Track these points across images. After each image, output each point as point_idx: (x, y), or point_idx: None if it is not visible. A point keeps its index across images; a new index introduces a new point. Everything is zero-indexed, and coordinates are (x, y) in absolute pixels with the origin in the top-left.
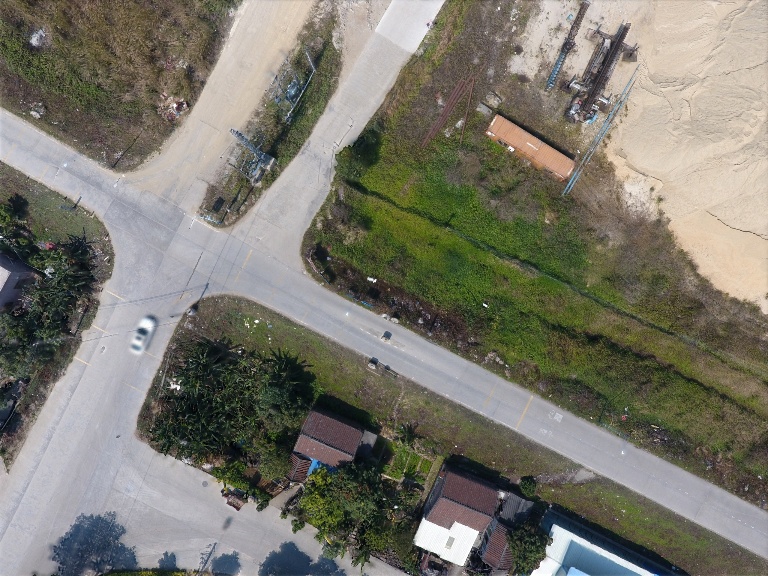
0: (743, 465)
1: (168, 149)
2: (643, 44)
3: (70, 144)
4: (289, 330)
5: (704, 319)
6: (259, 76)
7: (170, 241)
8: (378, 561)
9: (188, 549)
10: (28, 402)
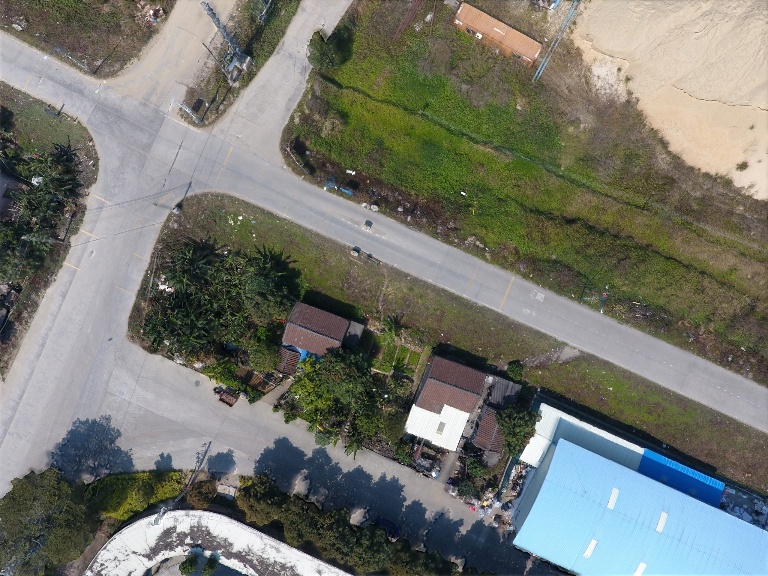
0: (726, 337)
1: (147, 55)
2: None
3: (52, 53)
4: (272, 224)
5: (677, 193)
6: None
7: (152, 143)
8: (372, 453)
9: (184, 449)
10: (21, 309)
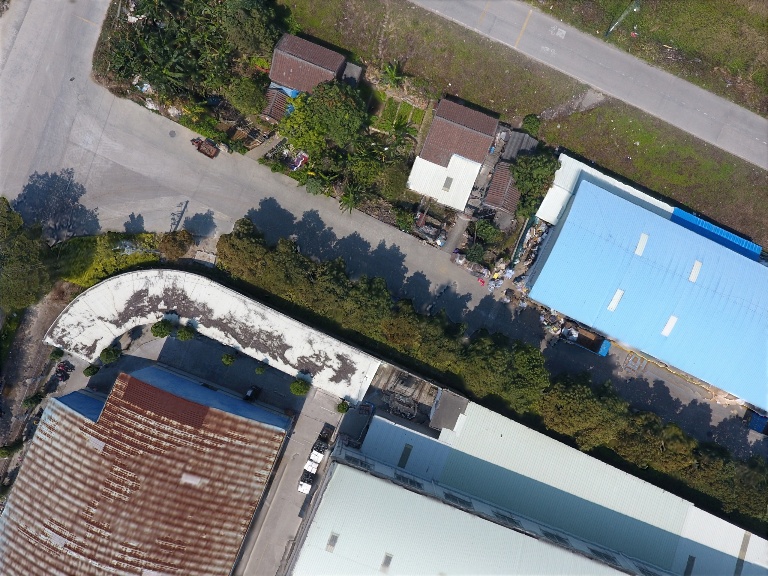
0: (765, 87)
1: None
2: None
3: None
4: None
5: None
6: None
7: None
8: (369, 217)
9: (157, 209)
10: None
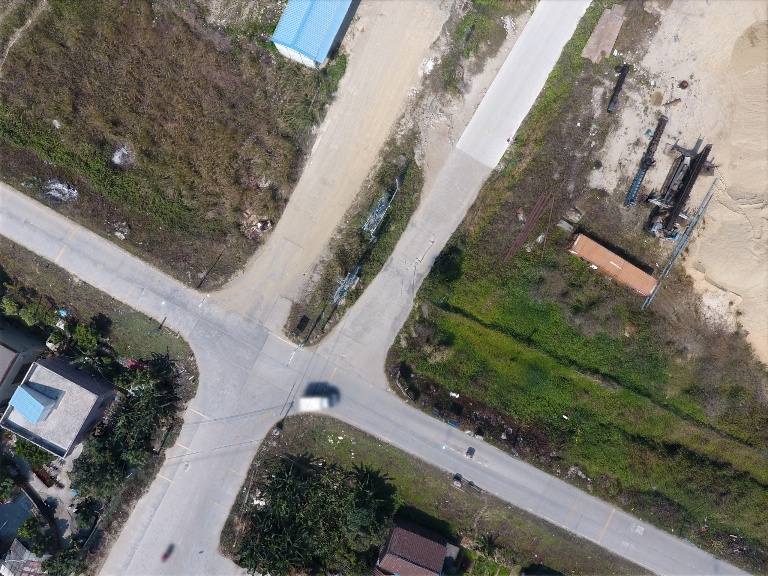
0: None
1: (251, 267)
2: (720, 158)
3: (155, 264)
4: (373, 447)
5: None
6: (341, 193)
7: (255, 360)
8: None
9: None
10: (111, 519)
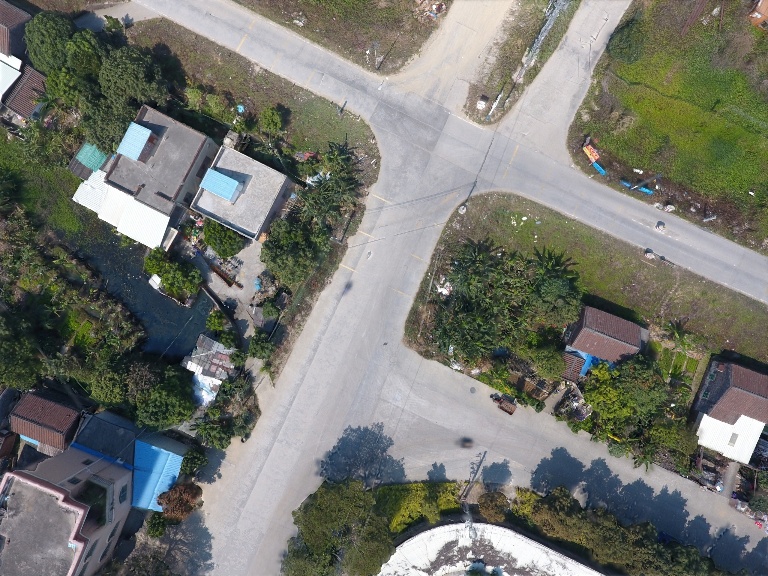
0: None
1: (427, 51)
2: None
3: (334, 50)
4: (559, 225)
5: None
6: None
7: (436, 141)
8: (653, 465)
9: (458, 459)
10: (294, 312)
